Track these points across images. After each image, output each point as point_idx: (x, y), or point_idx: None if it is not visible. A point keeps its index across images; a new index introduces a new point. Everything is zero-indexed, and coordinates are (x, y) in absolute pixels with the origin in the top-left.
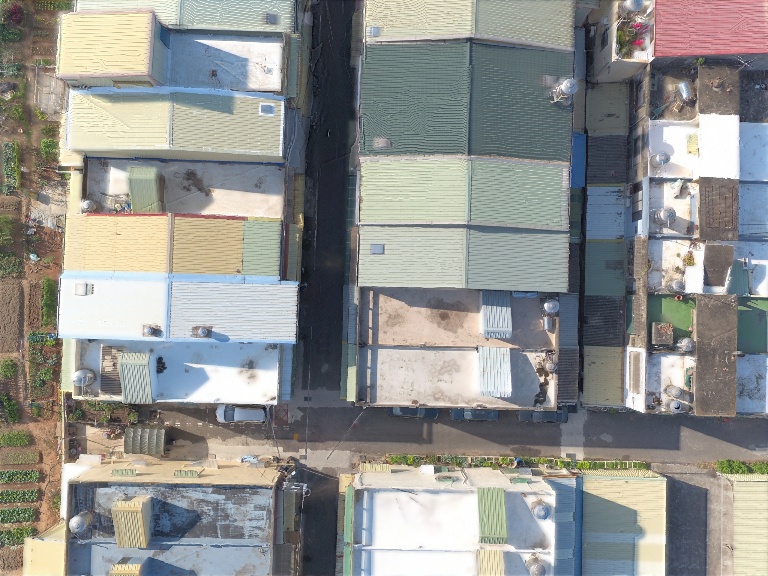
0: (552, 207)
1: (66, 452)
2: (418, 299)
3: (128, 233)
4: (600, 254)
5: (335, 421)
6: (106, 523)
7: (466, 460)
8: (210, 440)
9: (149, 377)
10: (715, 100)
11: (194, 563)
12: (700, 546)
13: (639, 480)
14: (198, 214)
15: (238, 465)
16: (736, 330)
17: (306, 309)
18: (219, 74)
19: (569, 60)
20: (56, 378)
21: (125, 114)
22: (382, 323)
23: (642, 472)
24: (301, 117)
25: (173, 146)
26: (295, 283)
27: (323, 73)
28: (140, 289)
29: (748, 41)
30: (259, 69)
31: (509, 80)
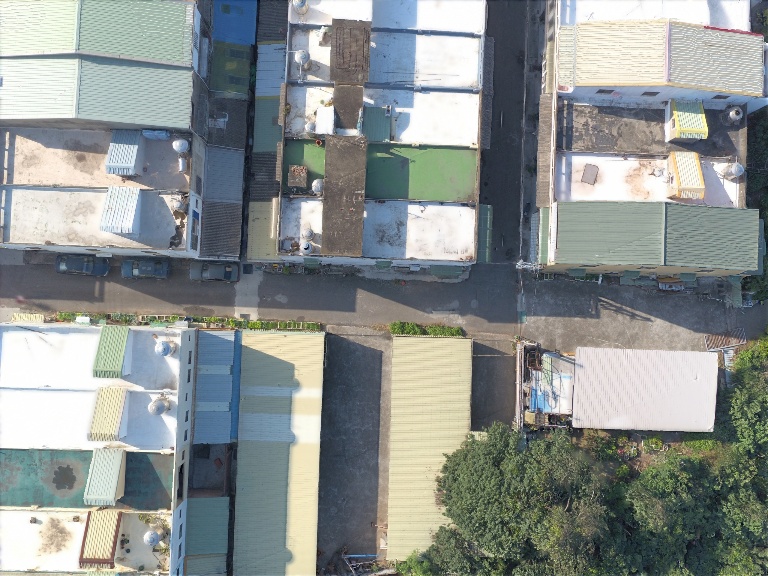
0: (172, 42)
1: None
2: (55, 140)
3: None
4: (267, 111)
5: (5, 278)
6: None
7: (137, 318)
8: None
9: None
10: None
11: None
12: (374, 408)
13: (298, 334)
14: None
15: None
16: (364, 171)
17: None
18: None
19: None
20: None
21: None
22: (17, 164)
23: None
24: None
25: None
26: None
27: None
28: None
29: None
30: None
31: None
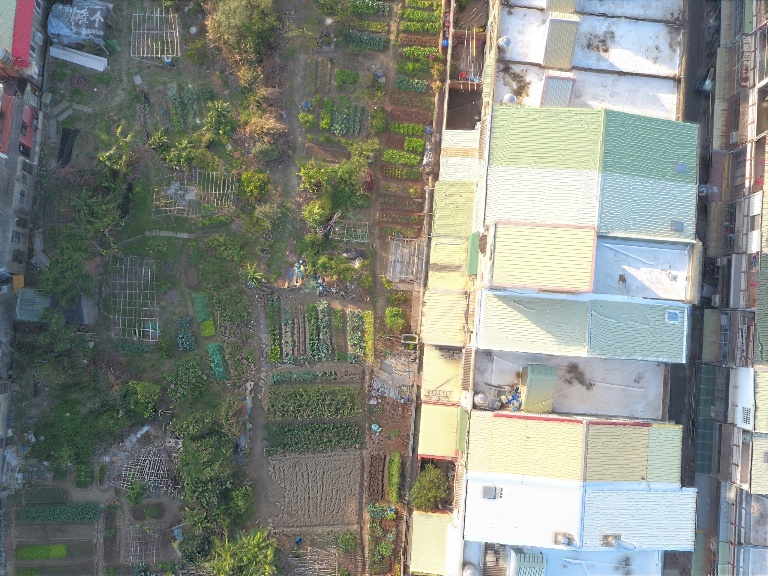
0: None
1: None
2: None
3: (538, 437)
4: None
5: None
6: None
7: None
8: None
9: None
10: None
11: None
12: None
13: None
14: (609, 421)
15: None
16: None
17: None
18: (626, 279)
19: None
20: (394, 552)
21: (550, 323)
22: (754, 522)
23: None
24: None
25: (591, 354)
26: (694, 490)
27: None
28: (551, 495)
29: None
30: (663, 275)
31: None
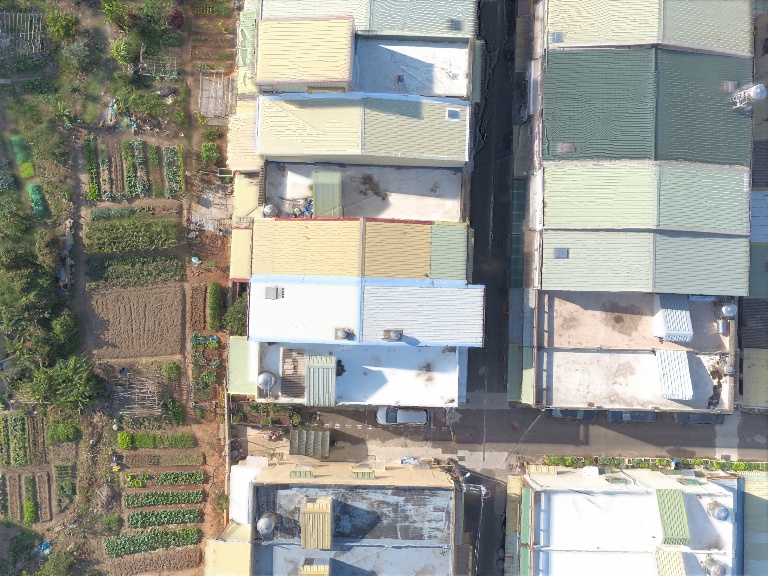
0: (734, 211)
1: (229, 454)
2: (593, 302)
3: (318, 237)
4: (759, 257)
5: (493, 423)
6: (287, 524)
7: (623, 461)
8: (369, 442)
9: (334, 380)
10: None
11: (375, 564)
12: None
13: None
14: (388, 219)
15: (401, 466)
16: None
17: None
18: (405, 79)
19: (748, 65)
20: (218, 380)
21: (320, 119)
22: (557, 326)
23: None
24: None
25: (365, 151)
26: (481, 287)
27: None
28: (331, 293)
29: None
30: (444, 74)
31: (692, 85)
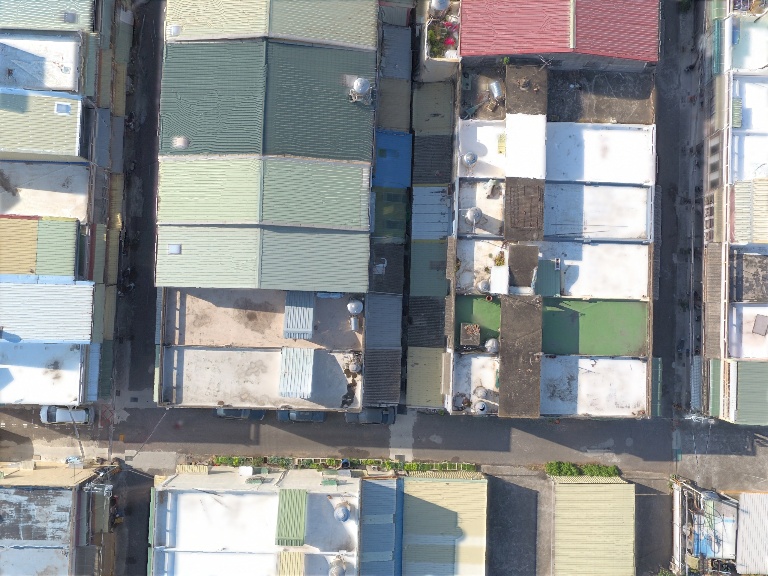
0: (350, 207)
1: None
2: (225, 299)
3: None
4: (424, 254)
5: (161, 422)
6: None
7: (293, 461)
8: (35, 441)
9: None
10: (522, 100)
11: None
12: (530, 549)
13: (460, 482)
14: None
15: (59, 466)
16: (541, 331)
17: (134, 309)
18: (15, 73)
19: (371, 59)
20: None
21: None
22: (189, 323)
23: (471, 474)
24: (109, 117)
25: None
26: (90, 283)
27: (141, 72)
28: None
29: (551, 40)
30: (56, 68)
31: (307, 79)
